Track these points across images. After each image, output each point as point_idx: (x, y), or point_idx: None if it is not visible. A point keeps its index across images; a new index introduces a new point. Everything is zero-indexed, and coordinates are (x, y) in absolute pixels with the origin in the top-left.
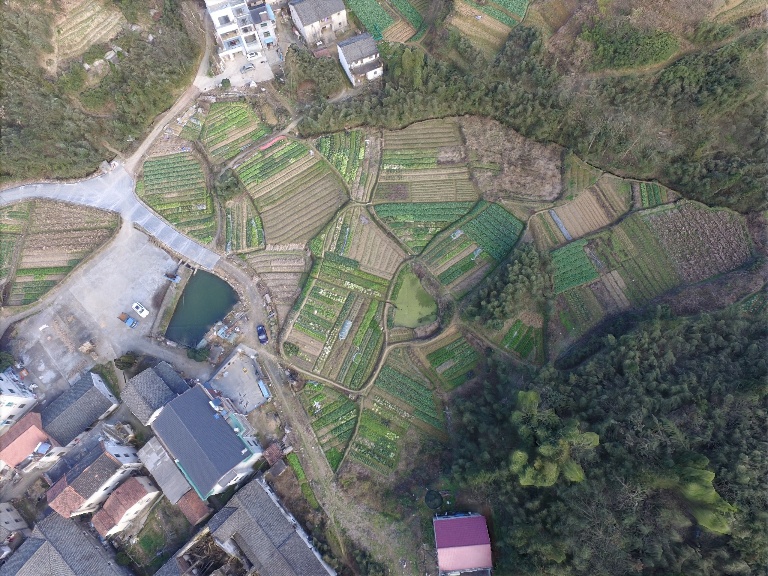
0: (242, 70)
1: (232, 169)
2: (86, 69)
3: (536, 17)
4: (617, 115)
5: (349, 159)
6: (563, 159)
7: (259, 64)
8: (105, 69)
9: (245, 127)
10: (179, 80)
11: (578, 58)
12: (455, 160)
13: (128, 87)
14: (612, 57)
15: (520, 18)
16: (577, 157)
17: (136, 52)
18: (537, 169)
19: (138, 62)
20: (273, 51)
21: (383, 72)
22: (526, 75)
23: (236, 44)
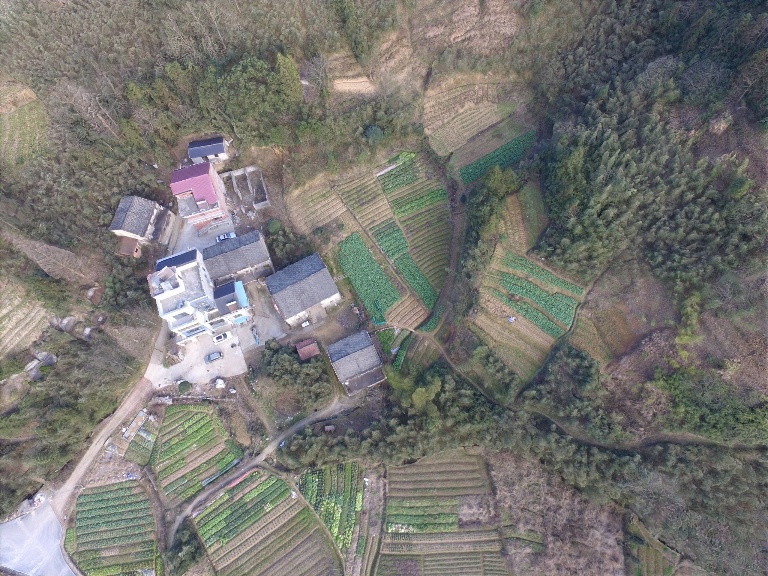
0: (206, 361)
1: (190, 519)
2: (1, 383)
3: (588, 328)
4: (706, 512)
5: (342, 510)
6: (626, 530)
7: (229, 348)
8: (26, 382)
9: (209, 447)
10: (124, 384)
11: (649, 411)
12: (482, 520)
13: (53, 417)
14: (698, 425)
15: (566, 327)
16: (644, 528)
17: (66, 361)
18: (591, 544)
19: (69, 373)
20: (247, 328)
21: (387, 378)
22: (578, 426)
23: (199, 329)
